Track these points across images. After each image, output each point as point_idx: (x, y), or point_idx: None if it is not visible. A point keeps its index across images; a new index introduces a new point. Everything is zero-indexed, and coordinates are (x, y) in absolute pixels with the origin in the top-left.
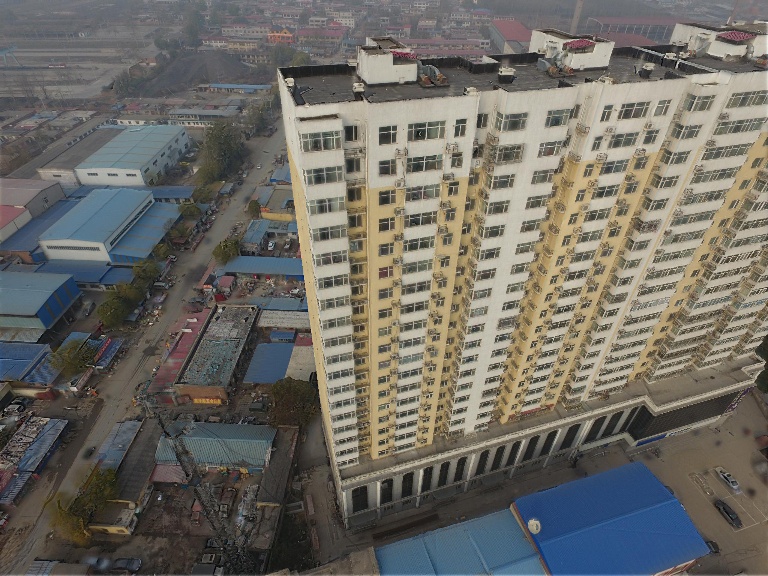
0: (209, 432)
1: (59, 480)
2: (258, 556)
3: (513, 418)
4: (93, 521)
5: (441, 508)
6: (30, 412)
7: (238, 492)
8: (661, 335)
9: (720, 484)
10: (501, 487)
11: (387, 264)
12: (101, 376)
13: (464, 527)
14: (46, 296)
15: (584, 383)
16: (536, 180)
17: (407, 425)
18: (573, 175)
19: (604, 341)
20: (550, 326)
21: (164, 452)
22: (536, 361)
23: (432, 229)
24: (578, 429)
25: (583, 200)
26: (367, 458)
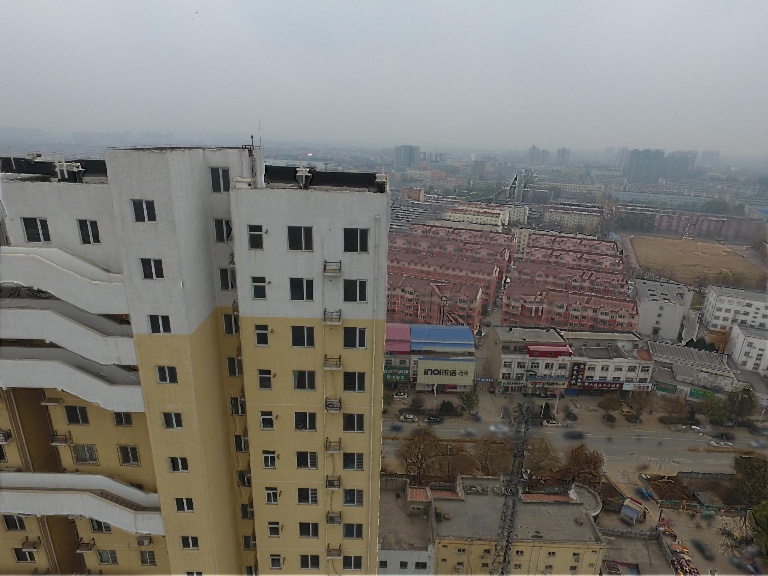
0: None
1: None
2: None
3: None
4: None
5: None
6: None
7: None
8: None
9: None
10: None
11: None
12: None
13: None
14: None
15: None
16: None
17: None
18: None
19: None
20: None
21: None
22: None
23: None
24: None
25: None
26: None
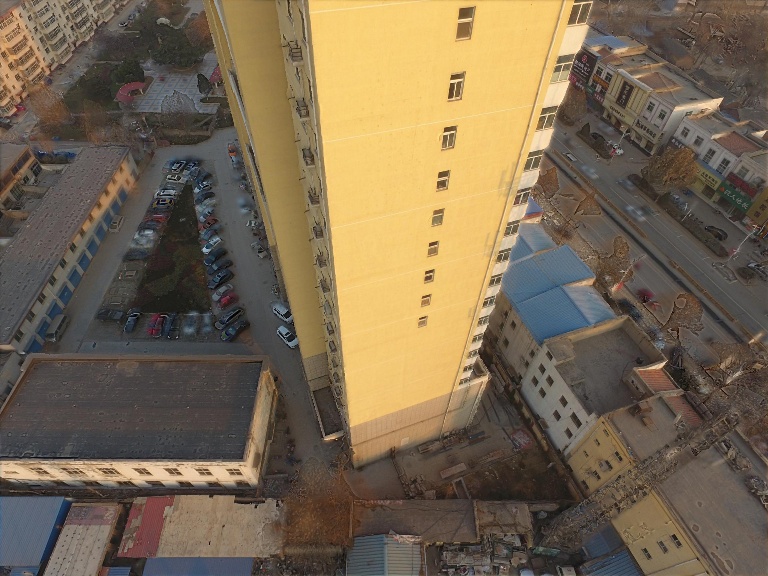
0: None
1: None
2: None
3: None
4: None
5: None
6: None
7: None
8: None
9: None
10: None
11: None
12: None
13: None
14: None
15: None
16: None
17: None
18: None
19: None
20: None
21: None
22: None
23: None
24: None
25: None
26: None
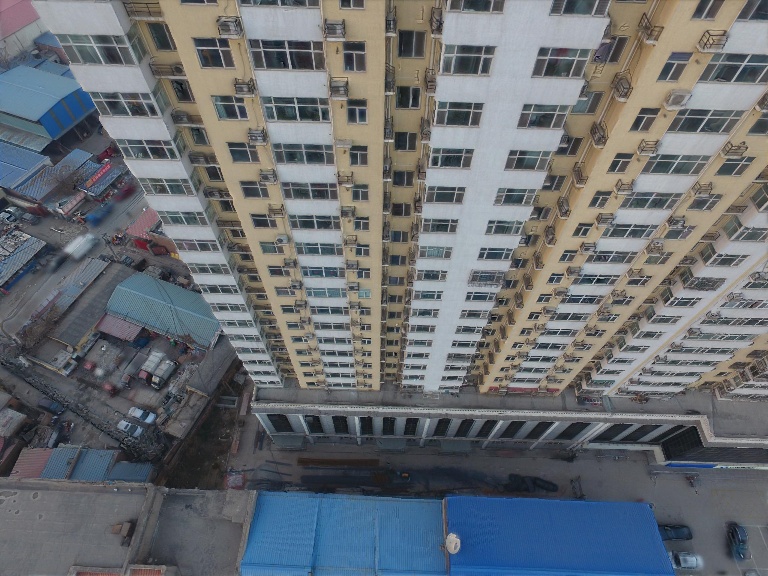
0: (166, 294)
1: (24, 301)
2: (172, 440)
3: (497, 390)
4: (30, 353)
5: (385, 455)
6: (13, 225)
7: (179, 366)
8: (767, 346)
9: (767, 549)
10: (467, 455)
11: (241, 137)
12: (94, 203)
13: (375, 504)
14: (52, 102)
15: (612, 377)
16: (565, 4)
17: (340, 365)
18: (668, 8)
19: (659, 336)
20: (566, 297)
21: (116, 303)
22: (536, 337)
23: (318, 82)
24: (586, 426)
25: (678, 79)
26: (295, 383)
